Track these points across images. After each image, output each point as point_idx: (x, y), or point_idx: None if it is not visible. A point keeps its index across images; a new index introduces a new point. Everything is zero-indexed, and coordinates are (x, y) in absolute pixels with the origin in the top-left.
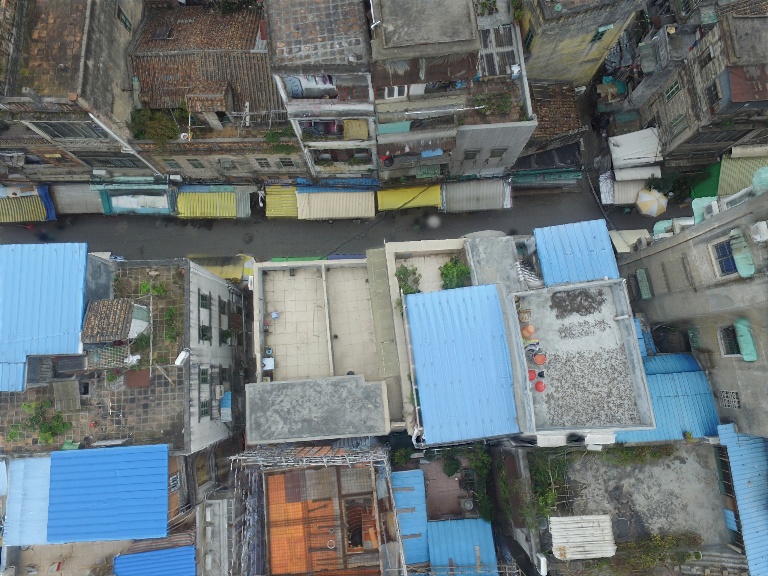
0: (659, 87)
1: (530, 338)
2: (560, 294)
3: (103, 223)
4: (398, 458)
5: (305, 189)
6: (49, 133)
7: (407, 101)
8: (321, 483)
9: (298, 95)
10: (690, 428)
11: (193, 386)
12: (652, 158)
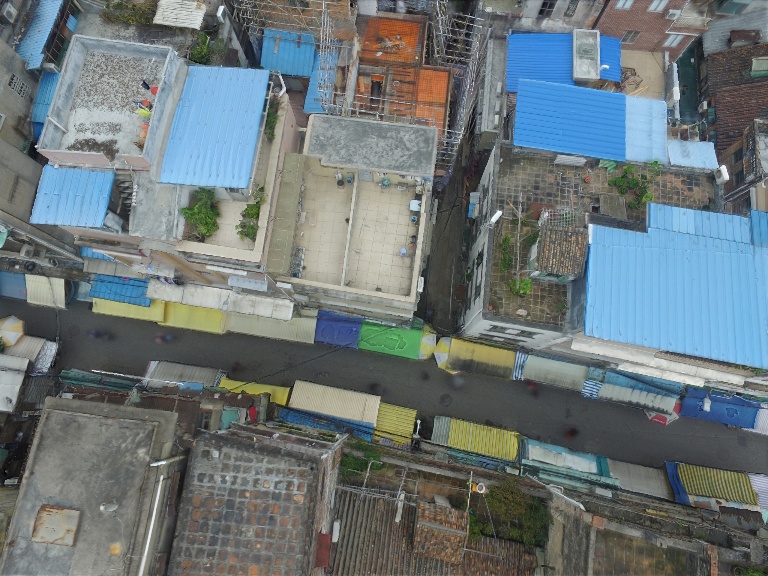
0: None
1: None
2: None
3: (615, 458)
4: None
5: None
6: None
7: None
8: None
9: None
10: None
11: None
12: None
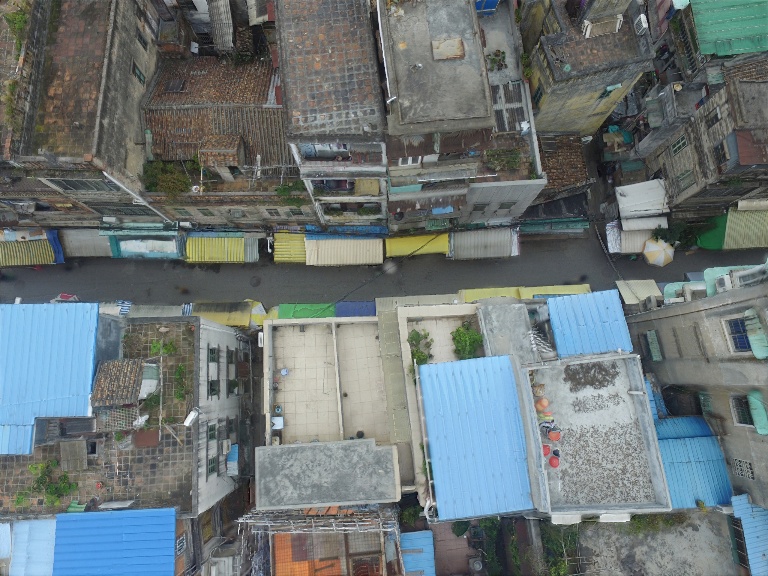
0: (665, 140)
1: (544, 411)
2: (574, 366)
3: (110, 264)
4: (407, 517)
5: (314, 236)
6: (62, 186)
7: (420, 168)
8: (328, 541)
9: (311, 156)
10: (703, 496)
11: (201, 445)
12: (659, 209)
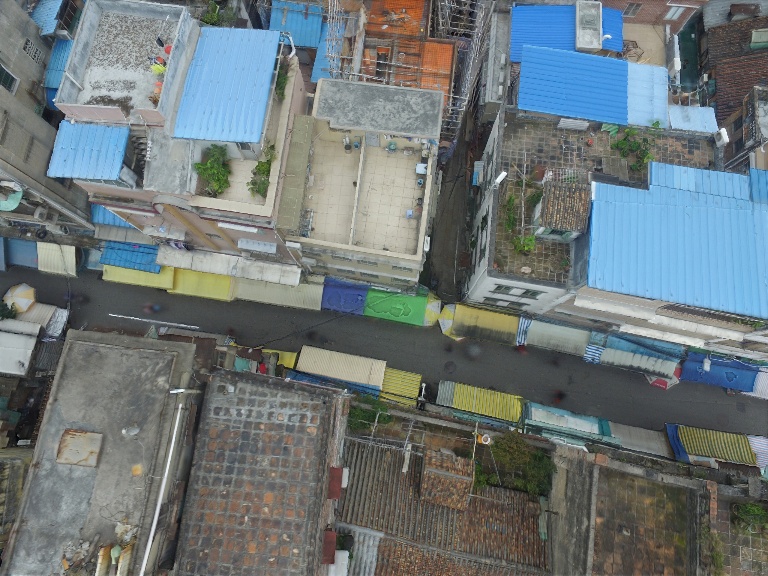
0: None
1: None
2: None
3: None
4: None
5: None
6: None
7: None
8: None
9: None
10: None
11: None
12: None
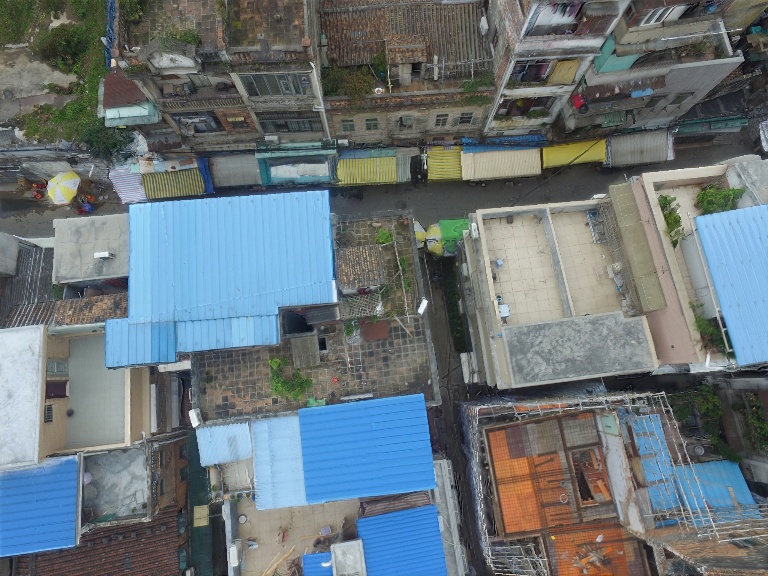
0: None
1: None
2: None
3: None
4: None
5: (471, 149)
6: (249, 91)
7: (662, 27)
8: (545, 437)
9: None
10: None
11: None
12: None
